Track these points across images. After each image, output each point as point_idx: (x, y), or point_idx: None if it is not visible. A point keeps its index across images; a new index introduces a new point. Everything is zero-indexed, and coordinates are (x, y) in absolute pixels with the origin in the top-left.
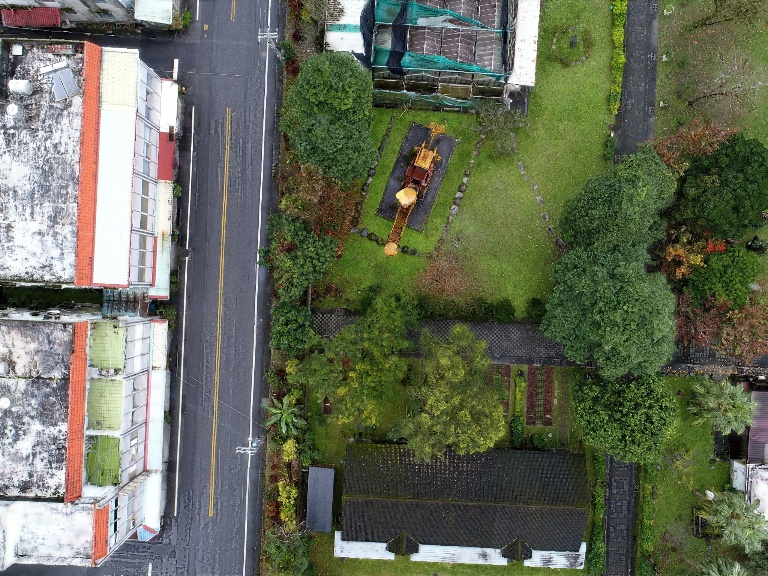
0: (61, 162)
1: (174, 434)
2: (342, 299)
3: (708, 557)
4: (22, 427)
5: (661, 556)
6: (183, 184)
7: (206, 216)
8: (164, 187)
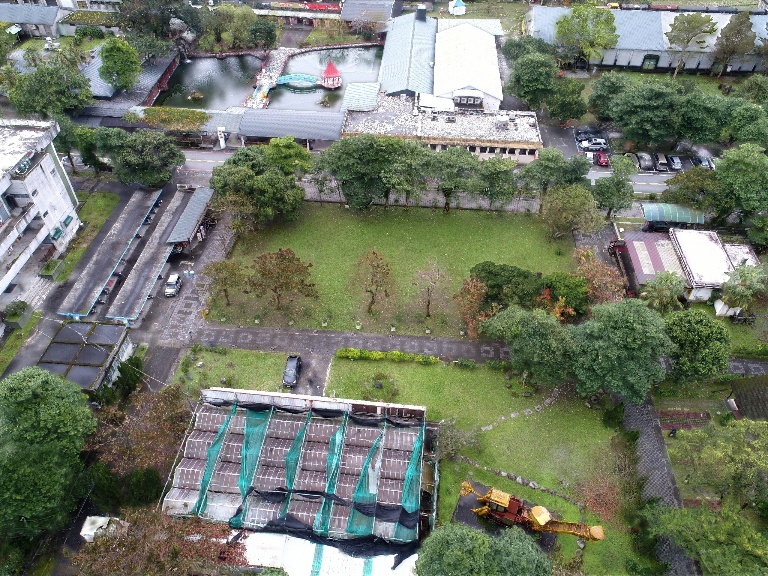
0: None
1: None
2: None
3: (766, 316)
4: None
5: None
6: None
7: None
8: None
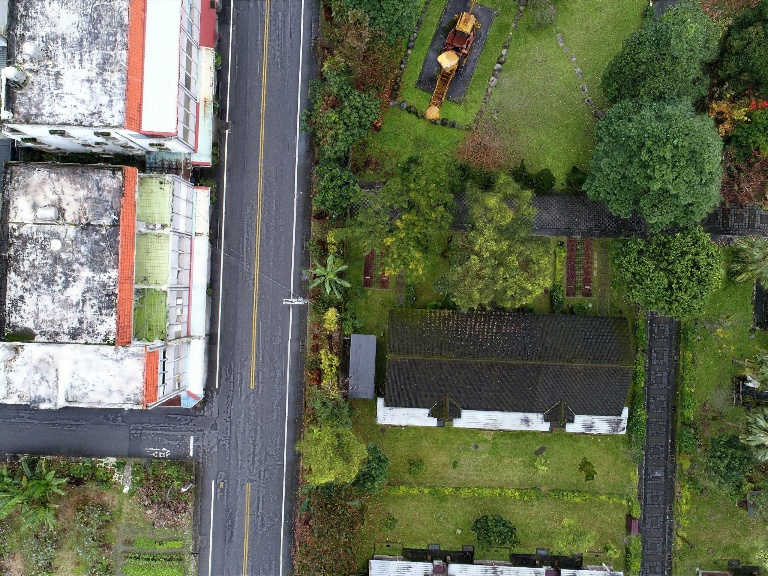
0: (109, 9)
1: (215, 307)
2: (381, 172)
3: None
4: (72, 274)
5: (701, 426)
6: (223, 57)
7: (246, 89)
8: (206, 54)
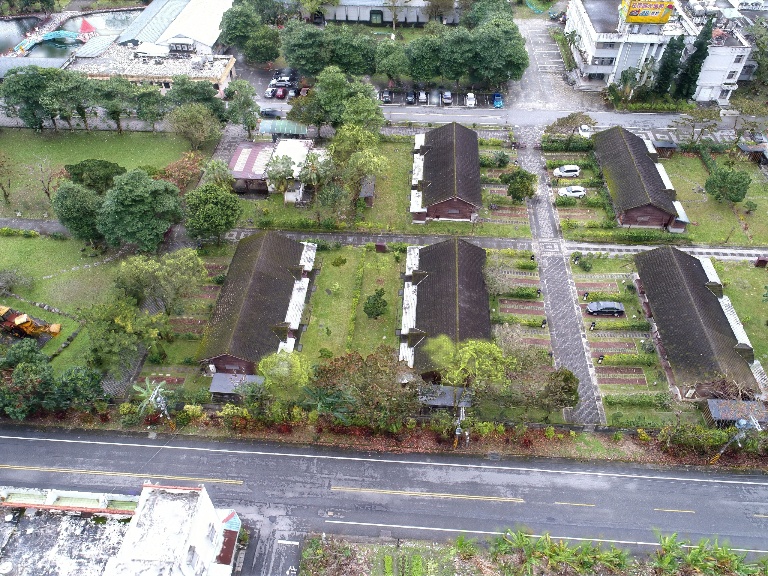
0: None
1: None
2: None
3: None
4: (46, 569)
5: None
6: None
7: None
8: None
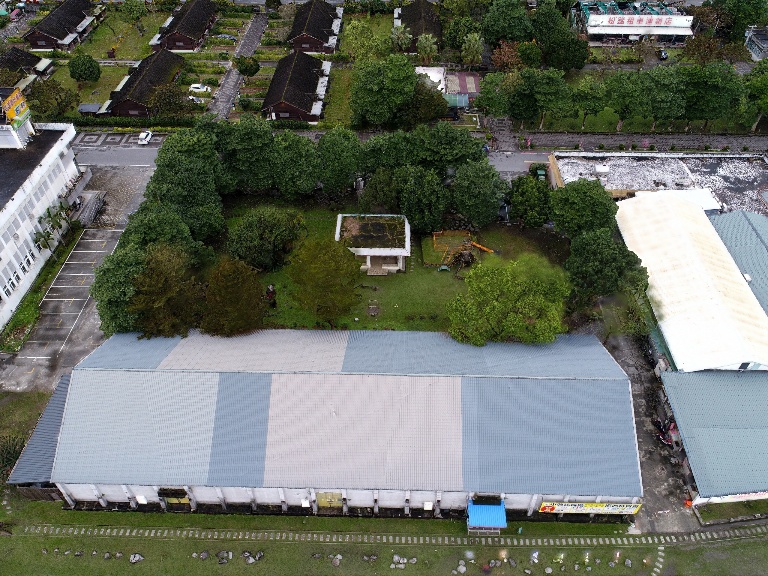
0: None
1: None
2: None
3: None
4: None
5: None
6: None
7: None
8: None
